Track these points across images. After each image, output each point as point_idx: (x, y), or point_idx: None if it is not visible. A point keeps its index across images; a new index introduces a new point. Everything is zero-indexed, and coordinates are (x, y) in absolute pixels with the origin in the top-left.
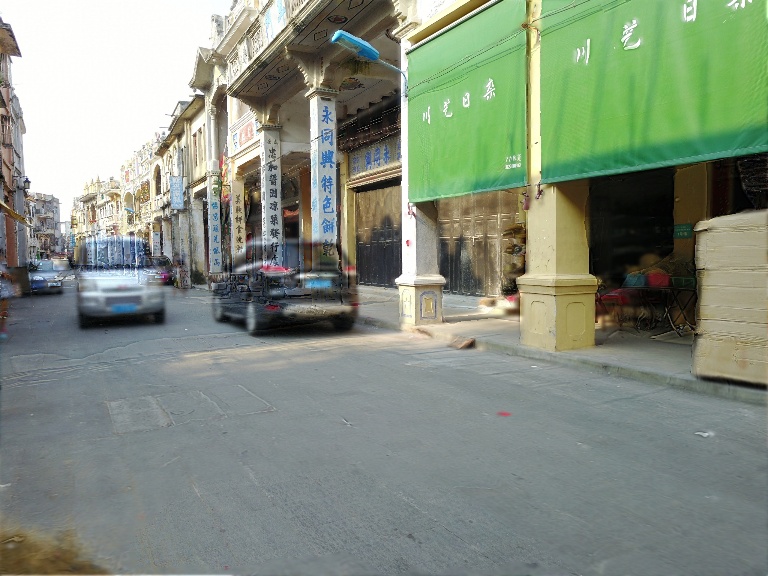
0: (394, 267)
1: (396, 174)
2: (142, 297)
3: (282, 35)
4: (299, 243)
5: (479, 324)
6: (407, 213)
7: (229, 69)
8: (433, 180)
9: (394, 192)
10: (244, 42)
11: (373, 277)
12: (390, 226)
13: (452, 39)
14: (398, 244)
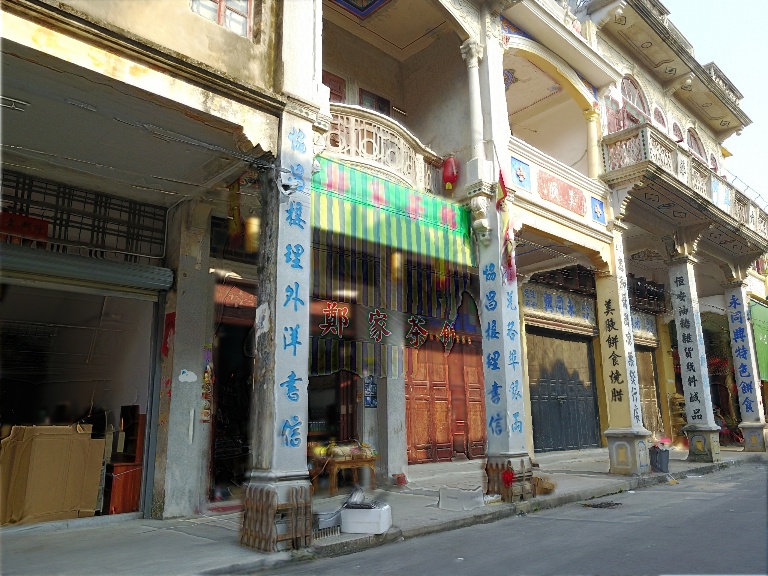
0: (573, 426)
1: (588, 333)
2: (759, 532)
3: (731, 219)
4: (388, 386)
5: (741, 449)
6: (757, 385)
7: (650, 140)
8: (766, 371)
9: (565, 346)
10: (683, 156)
11: (545, 440)
12: (564, 381)
13: (761, 309)
14: (575, 401)
